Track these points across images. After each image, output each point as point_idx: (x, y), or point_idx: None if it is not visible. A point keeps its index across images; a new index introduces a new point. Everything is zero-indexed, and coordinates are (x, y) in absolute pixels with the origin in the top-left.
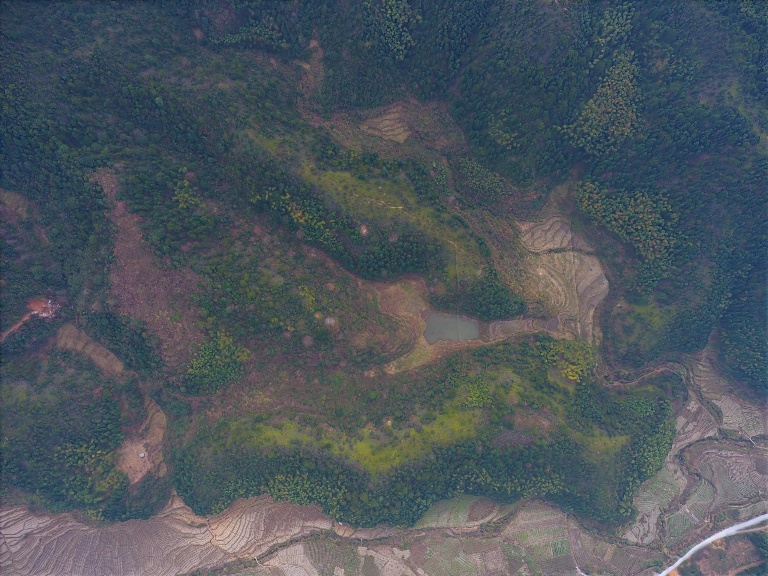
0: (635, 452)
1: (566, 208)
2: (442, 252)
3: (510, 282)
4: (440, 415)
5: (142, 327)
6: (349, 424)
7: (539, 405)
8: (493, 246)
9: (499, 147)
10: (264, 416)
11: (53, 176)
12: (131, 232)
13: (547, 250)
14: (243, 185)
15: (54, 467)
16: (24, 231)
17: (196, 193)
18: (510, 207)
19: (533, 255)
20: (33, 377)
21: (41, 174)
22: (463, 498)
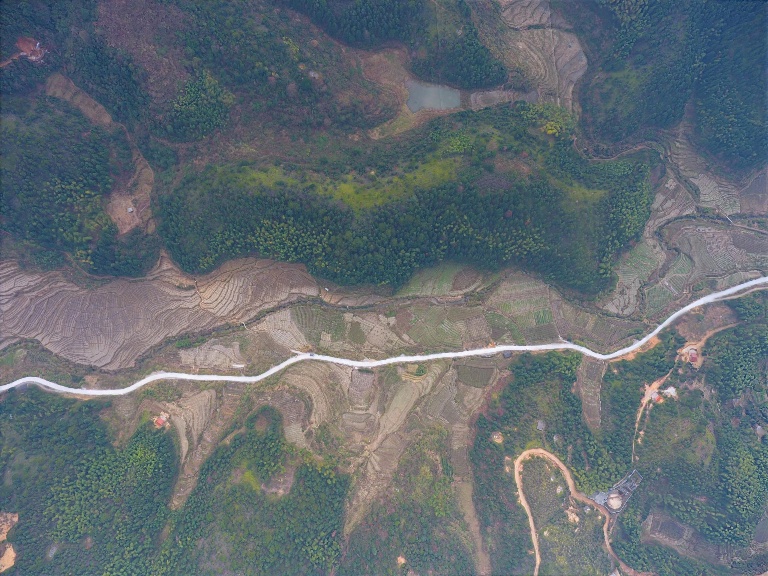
0: (613, 207)
1: None
2: (423, 11)
3: (490, 46)
4: (422, 165)
5: (129, 58)
6: (333, 170)
7: (518, 148)
8: (473, 10)
9: None
10: (250, 161)
11: None
12: None
13: (527, 26)
14: None
15: (43, 203)
16: None
17: None
18: None
19: (513, 31)
20: (22, 111)
21: None
22: (447, 268)
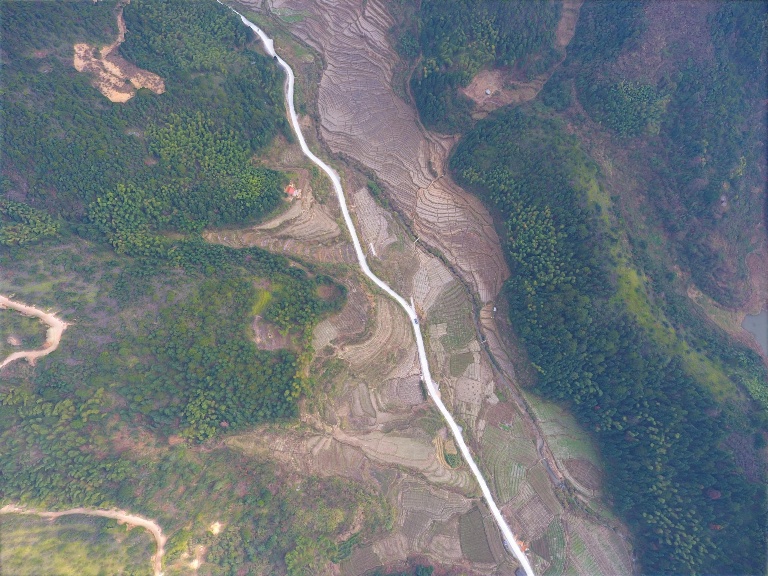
0: None
1: None
2: None
3: None
4: (705, 356)
5: (643, 29)
6: None
7: None
8: None
9: None
10: None
11: None
12: None
13: None
14: None
15: None
16: None
17: None
18: None
19: None
20: None
21: None
22: (586, 443)
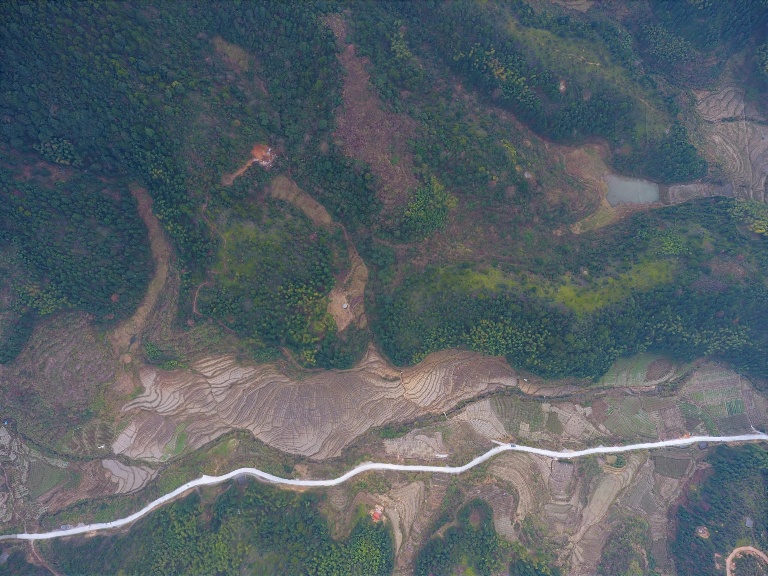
0: None
1: (742, 76)
2: (633, 111)
3: (694, 143)
4: (635, 265)
5: (366, 168)
6: (550, 271)
7: (735, 251)
8: None
9: (691, 7)
10: (470, 262)
11: (285, 21)
12: (359, 75)
13: (721, 119)
14: (447, 43)
15: (277, 306)
16: (247, 81)
17: (407, 47)
18: (689, 74)
19: (708, 123)
20: (259, 218)
21: (273, 20)
22: (641, 358)
